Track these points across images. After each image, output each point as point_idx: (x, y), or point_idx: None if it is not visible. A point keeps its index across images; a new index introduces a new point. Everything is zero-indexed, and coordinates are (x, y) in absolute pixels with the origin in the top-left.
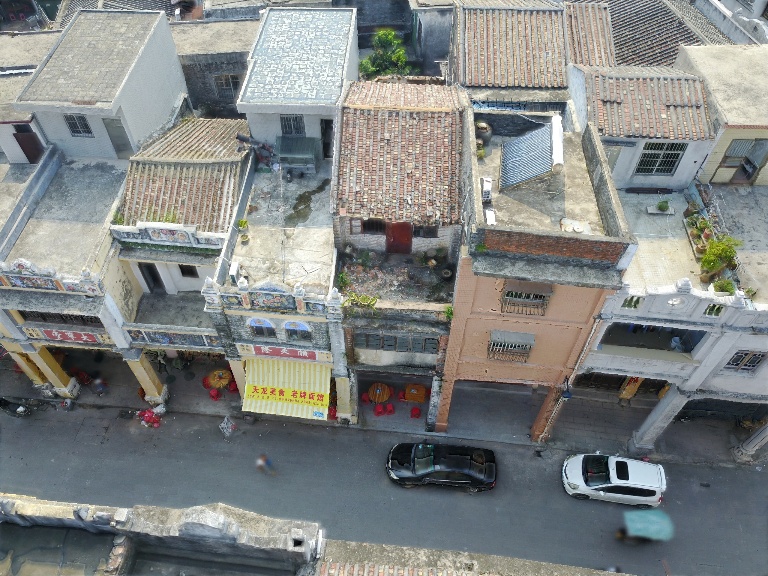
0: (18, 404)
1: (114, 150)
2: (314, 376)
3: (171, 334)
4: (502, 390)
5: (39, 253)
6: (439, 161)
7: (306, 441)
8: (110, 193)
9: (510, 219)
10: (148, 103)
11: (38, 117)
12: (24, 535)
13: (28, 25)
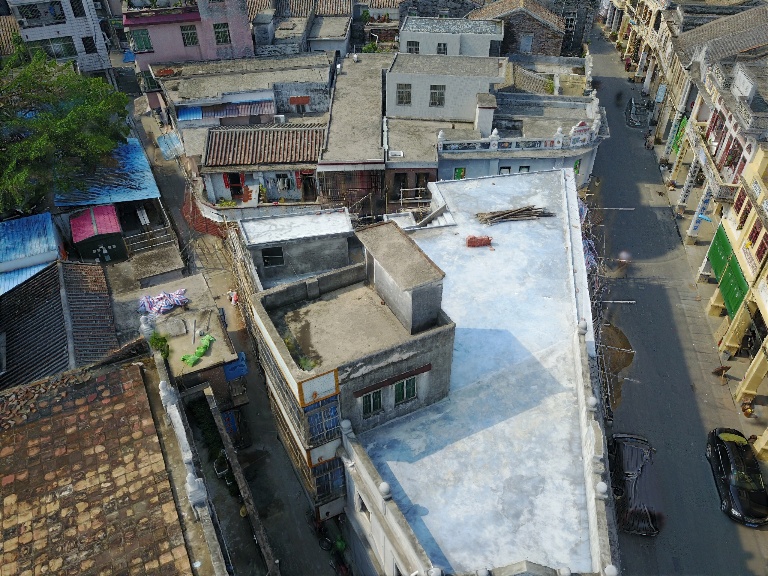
0: None
1: None
2: None
3: None
4: None
5: None
6: None
7: None
8: None
9: None
10: None
11: None
12: None
13: None
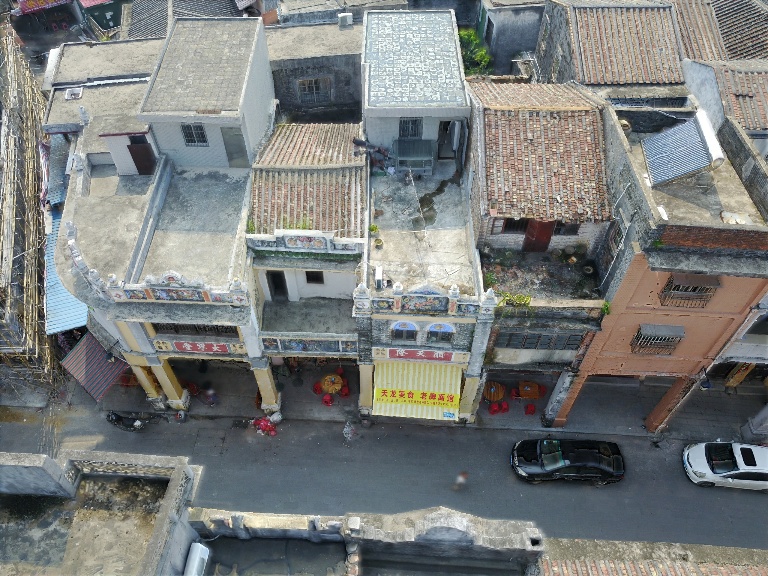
0: (132, 418)
1: (227, 158)
2: (444, 377)
3: (307, 341)
4: (610, 383)
5: (174, 265)
6: (584, 159)
7: (425, 442)
8: (230, 202)
9: (671, 214)
10: (256, 110)
11: (154, 128)
12: (244, 548)
13: (72, 34)
